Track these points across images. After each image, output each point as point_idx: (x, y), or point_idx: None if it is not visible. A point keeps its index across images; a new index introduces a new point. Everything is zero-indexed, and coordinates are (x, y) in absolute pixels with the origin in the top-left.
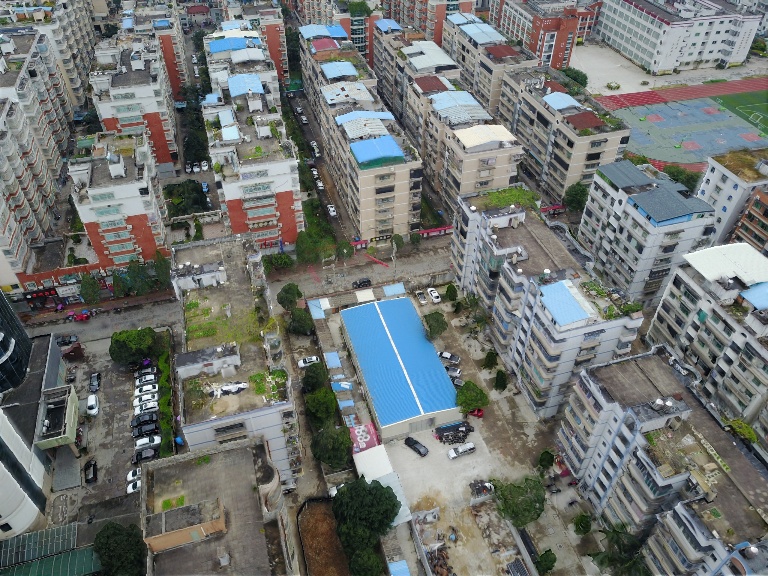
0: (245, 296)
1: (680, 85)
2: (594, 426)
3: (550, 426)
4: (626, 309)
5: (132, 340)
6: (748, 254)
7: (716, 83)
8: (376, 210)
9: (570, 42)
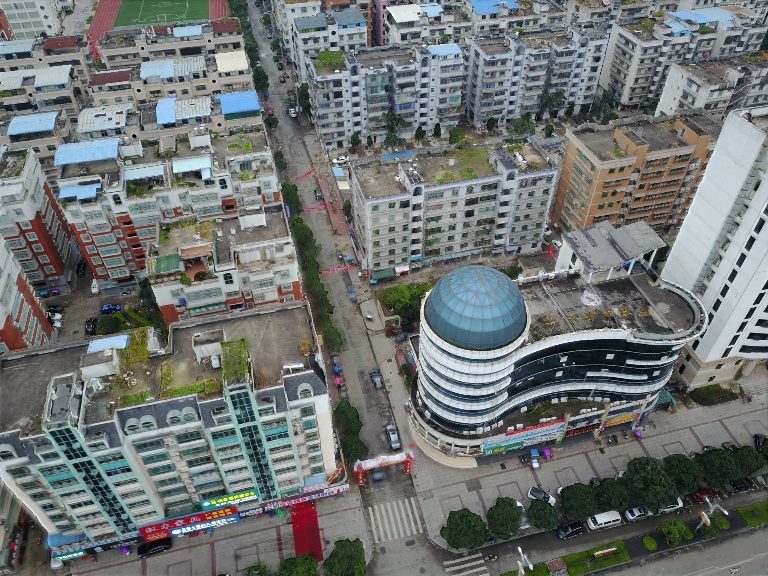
0: (428, 161)
1: (85, 32)
2: (505, 74)
3: None
4: (447, 37)
5: (409, 290)
6: (397, 8)
7: (94, 19)
8: None
9: (12, 35)
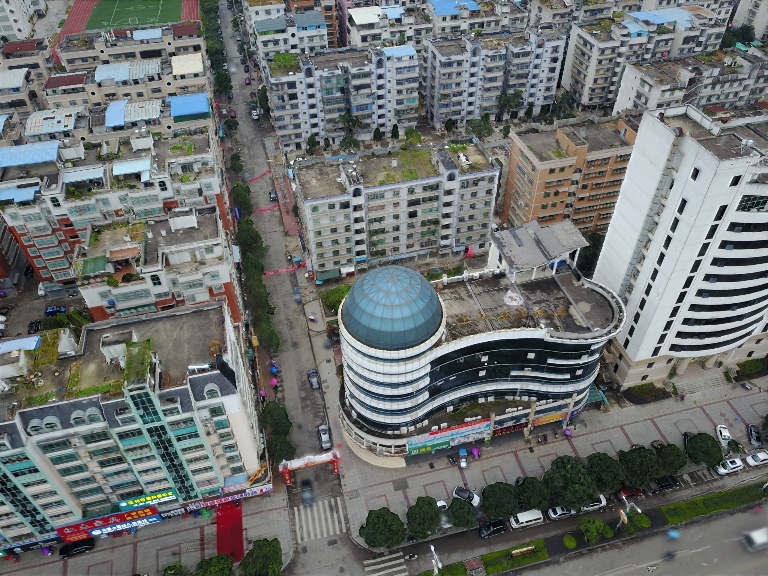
0: (372, 162)
1: None
2: (462, 75)
3: (418, 131)
4: (404, 39)
5: None
6: (359, 10)
7: (66, 23)
8: (219, 152)
9: None
